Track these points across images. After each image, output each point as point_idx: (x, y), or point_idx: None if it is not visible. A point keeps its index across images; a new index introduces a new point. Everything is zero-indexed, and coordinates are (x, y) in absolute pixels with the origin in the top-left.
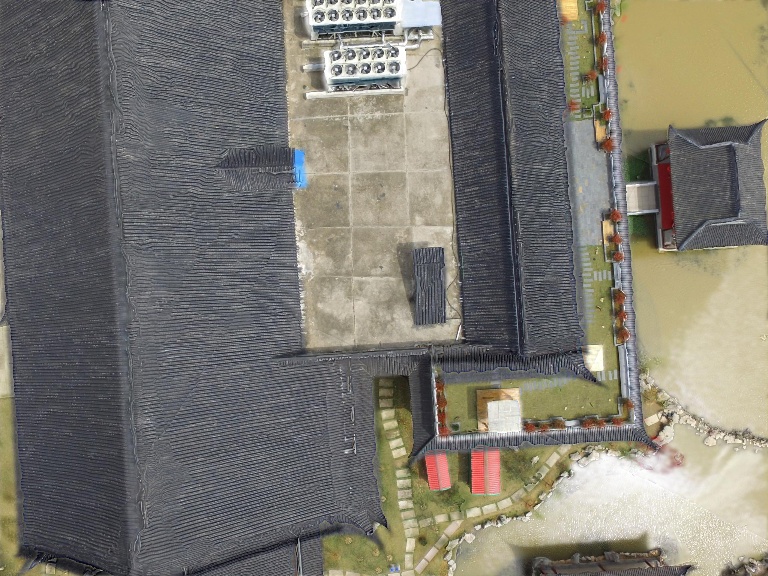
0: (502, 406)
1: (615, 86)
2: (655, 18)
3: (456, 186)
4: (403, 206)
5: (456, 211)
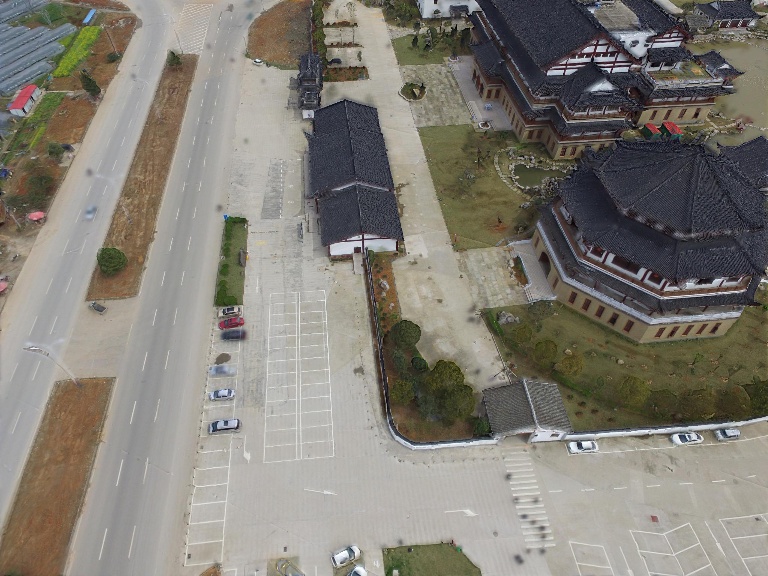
0: None
1: None
2: None
3: None
4: (626, 19)
5: None
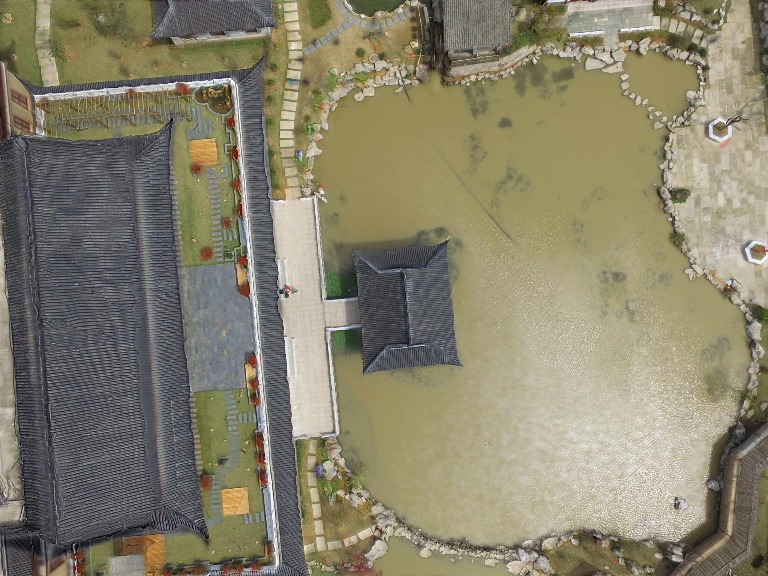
0: (126, 561)
1: (269, 223)
2: (377, 125)
3: (15, 368)
4: None
5: (16, 393)
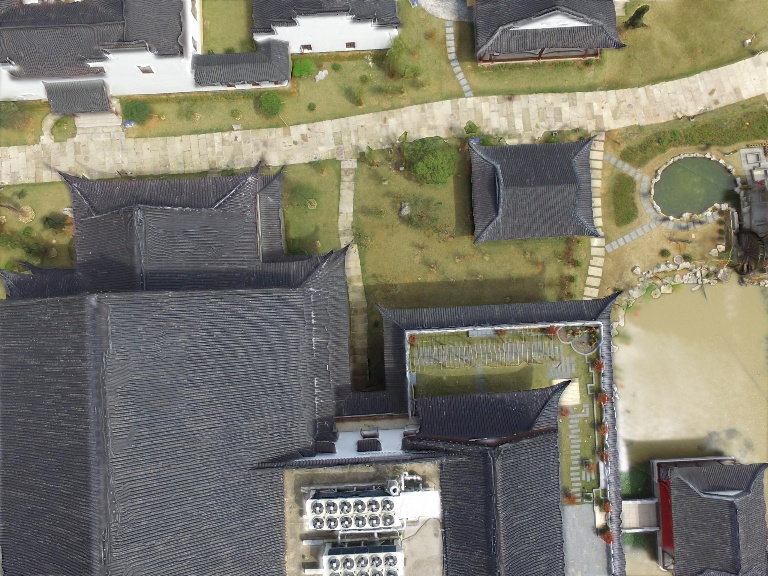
0: None
1: (616, 457)
2: (660, 313)
3: None
4: None
5: None
